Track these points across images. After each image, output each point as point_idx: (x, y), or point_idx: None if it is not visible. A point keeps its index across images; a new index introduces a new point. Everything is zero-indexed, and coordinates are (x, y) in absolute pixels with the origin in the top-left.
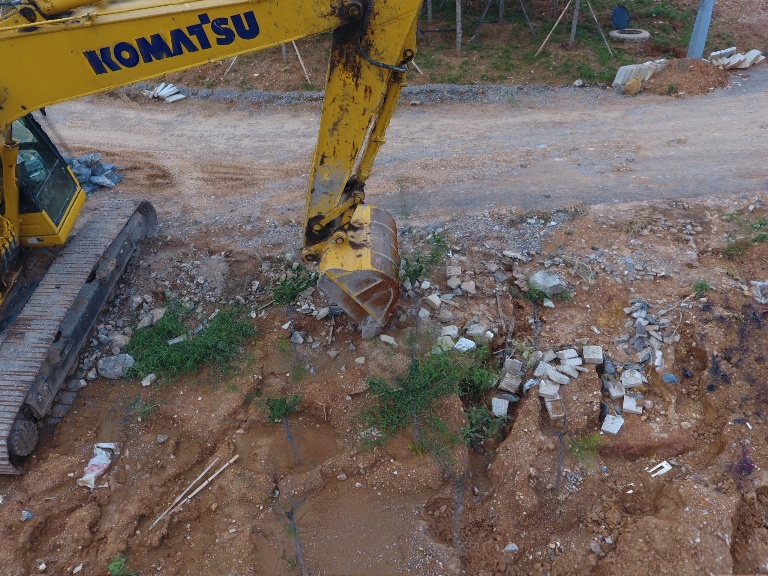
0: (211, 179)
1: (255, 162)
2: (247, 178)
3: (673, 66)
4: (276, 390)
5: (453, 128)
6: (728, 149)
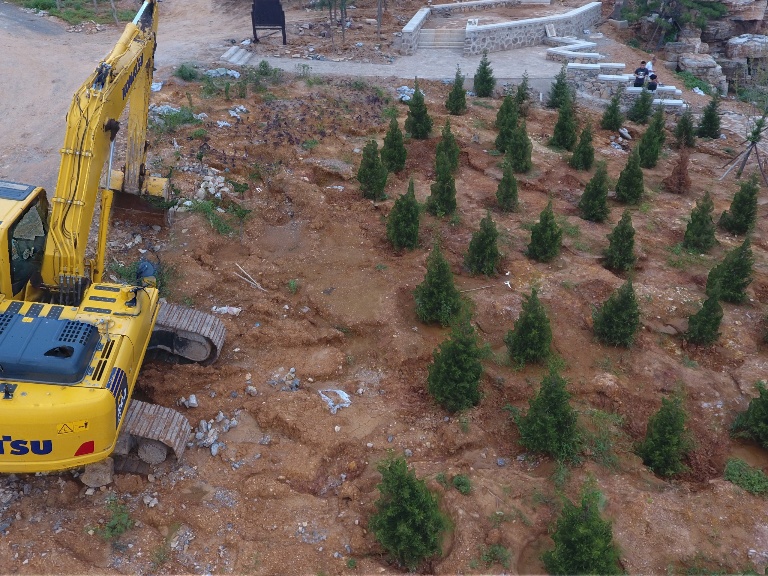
0: None
1: None
2: None
3: None
4: (200, 250)
5: None
6: (54, 126)
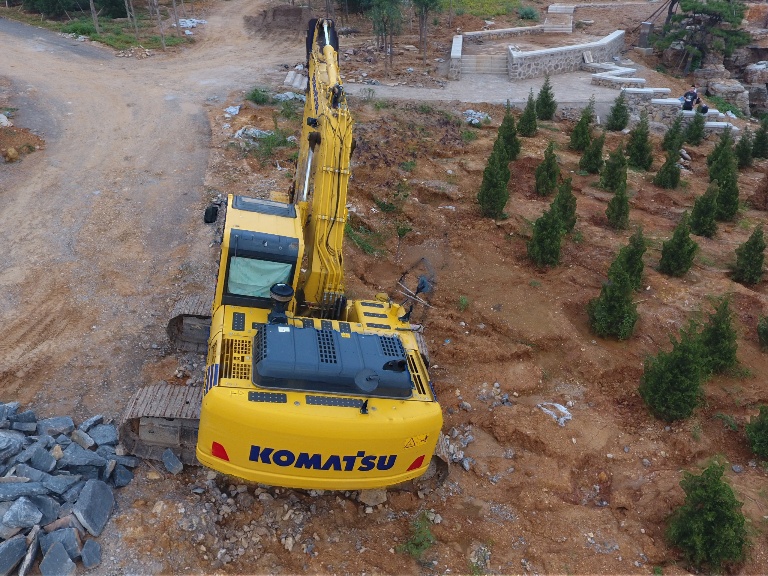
0: (39, 339)
1: (7, 318)
2: (55, 315)
3: (3, 135)
4: (360, 269)
5: (15, 223)
6: (152, 149)
